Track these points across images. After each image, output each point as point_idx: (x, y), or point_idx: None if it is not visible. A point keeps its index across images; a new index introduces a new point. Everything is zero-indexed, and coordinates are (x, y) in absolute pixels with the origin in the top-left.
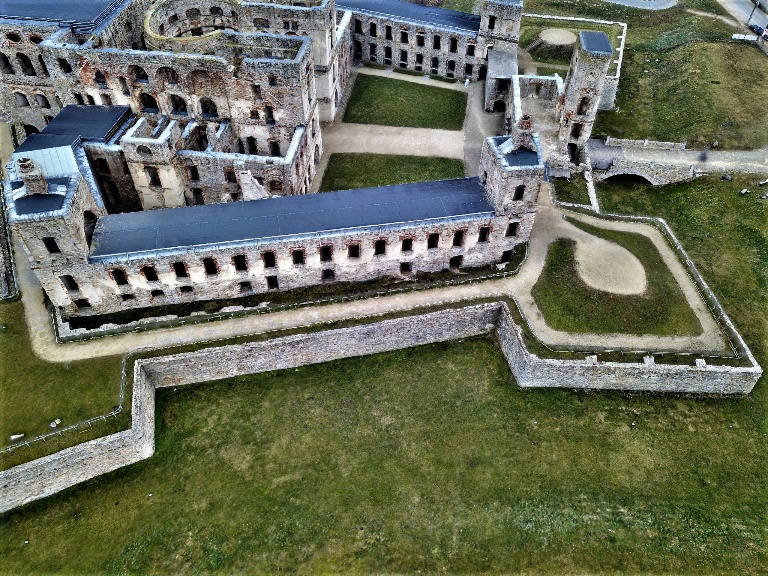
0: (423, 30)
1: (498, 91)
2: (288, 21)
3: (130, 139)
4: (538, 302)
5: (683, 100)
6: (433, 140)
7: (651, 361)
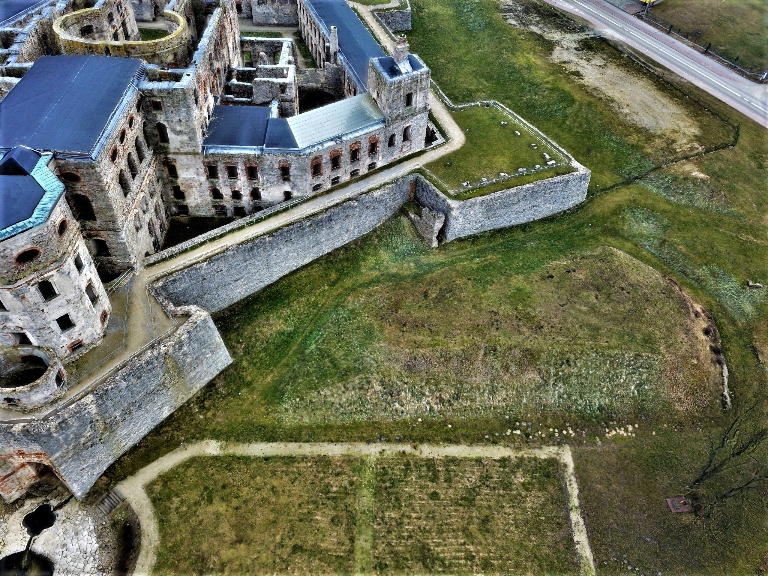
0: (54, 5)
1: None
2: (117, 4)
3: (291, 78)
4: (373, 4)
5: None
6: None
7: None
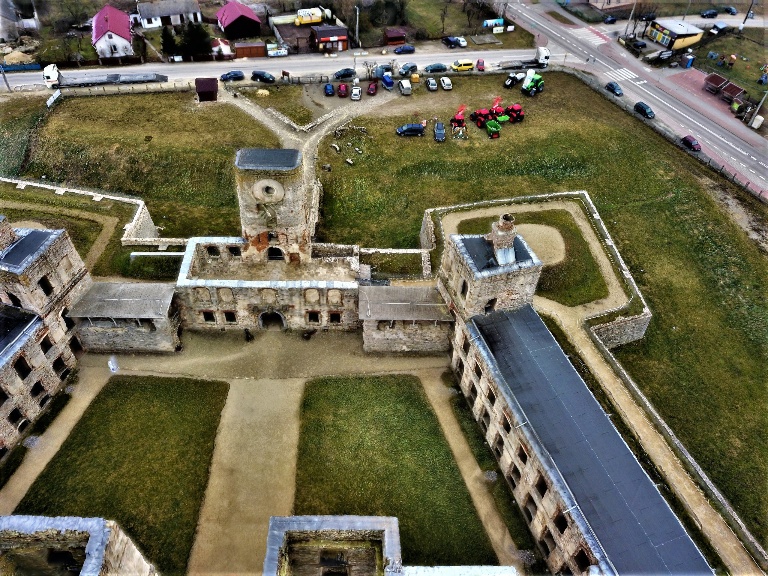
0: None
1: (172, 319)
2: None
3: None
4: (582, 302)
5: (169, 170)
6: (255, 419)
7: (609, 241)
